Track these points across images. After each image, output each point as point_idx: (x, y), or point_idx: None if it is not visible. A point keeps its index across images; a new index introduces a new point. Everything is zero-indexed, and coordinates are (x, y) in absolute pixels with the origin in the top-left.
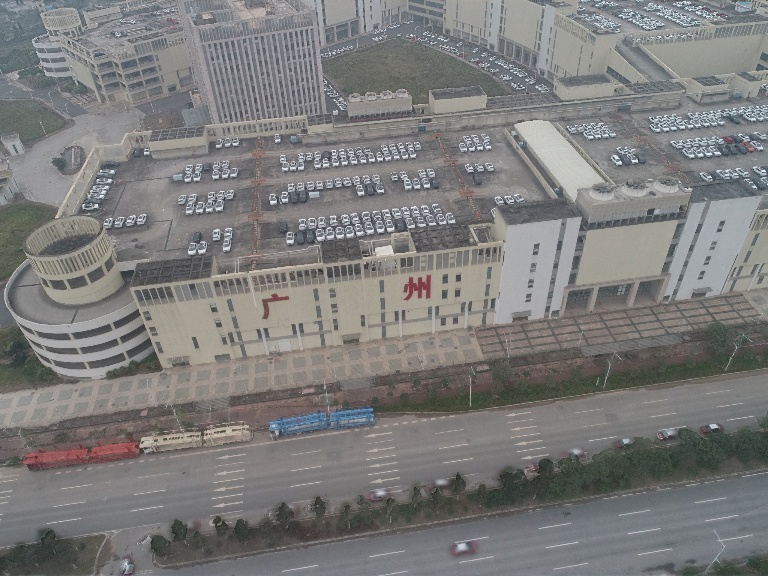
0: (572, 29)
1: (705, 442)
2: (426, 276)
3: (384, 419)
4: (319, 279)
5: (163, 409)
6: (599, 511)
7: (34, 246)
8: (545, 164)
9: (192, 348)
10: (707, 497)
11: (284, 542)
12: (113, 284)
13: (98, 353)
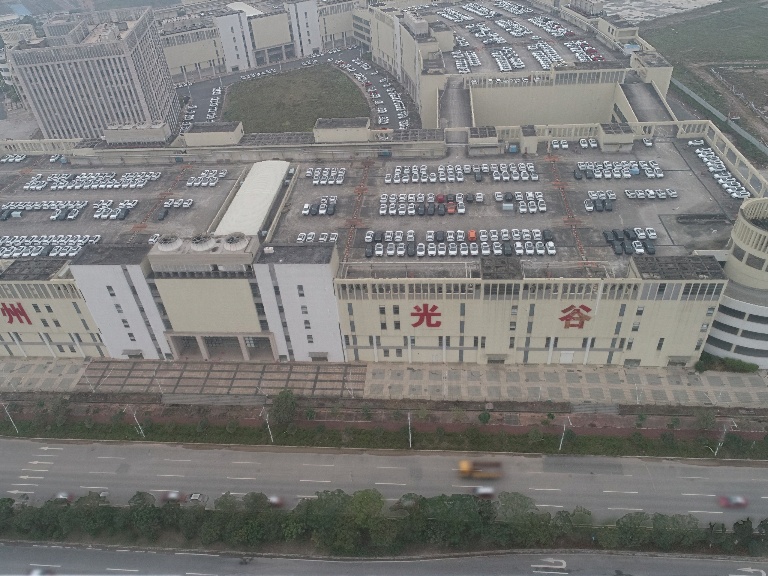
0: None
1: (142, 510)
2: (16, 303)
3: None
4: None
5: None
6: (18, 556)
7: None
8: (229, 206)
9: None
10: (123, 566)
11: None
12: None
13: None
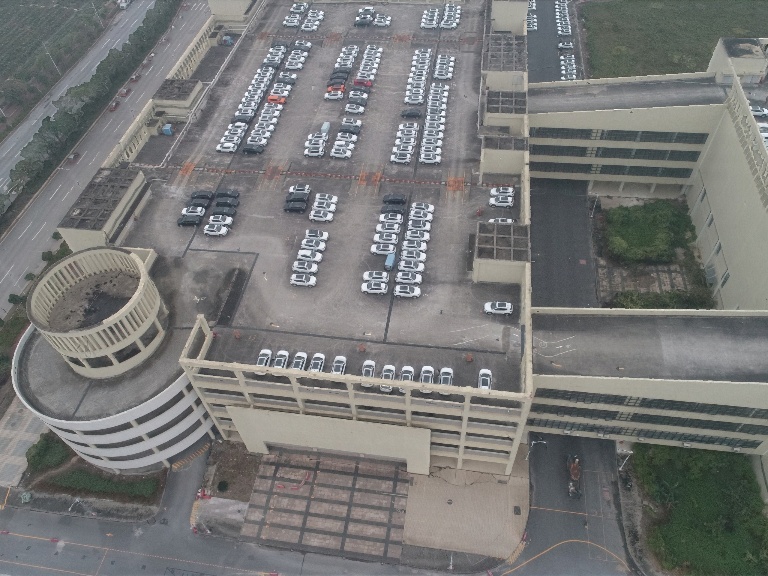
0: None
1: (139, 31)
2: None
3: None
4: None
5: None
6: None
7: None
8: None
9: None
10: None
11: None
12: None
13: None
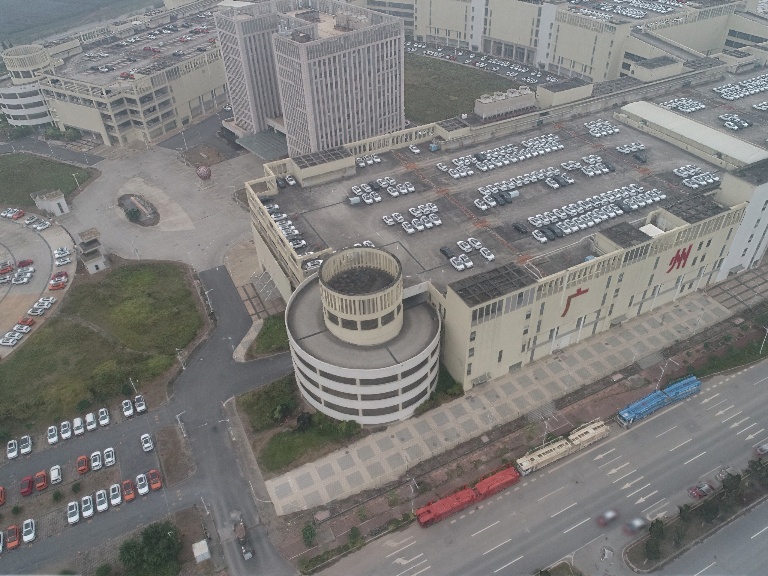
0: (580, 22)
1: None
2: (689, 246)
3: (701, 384)
4: (615, 266)
5: (500, 430)
6: None
7: None
8: (686, 136)
9: (495, 363)
10: None
11: (730, 513)
12: None
13: (415, 390)
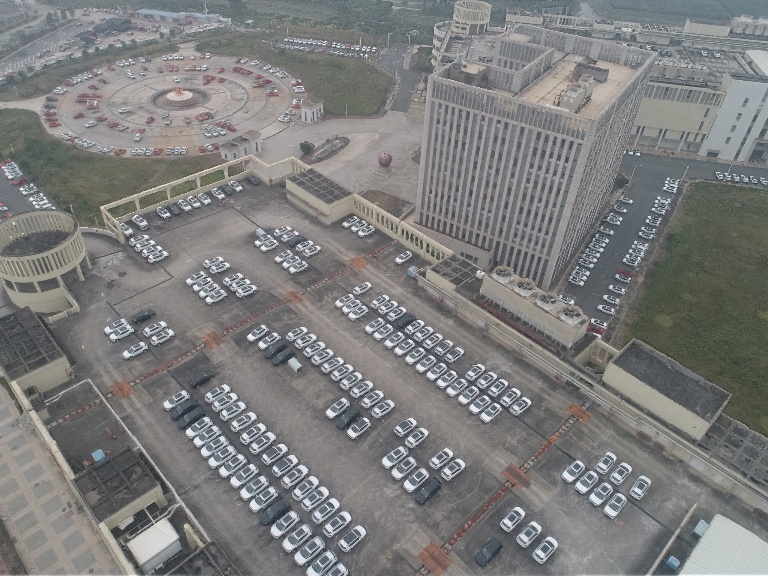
0: None
1: None
2: None
3: None
4: None
5: None
6: None
7: (28, 224)
8: None
9: None
10: None
11: None
12: (47, 305)
13: None
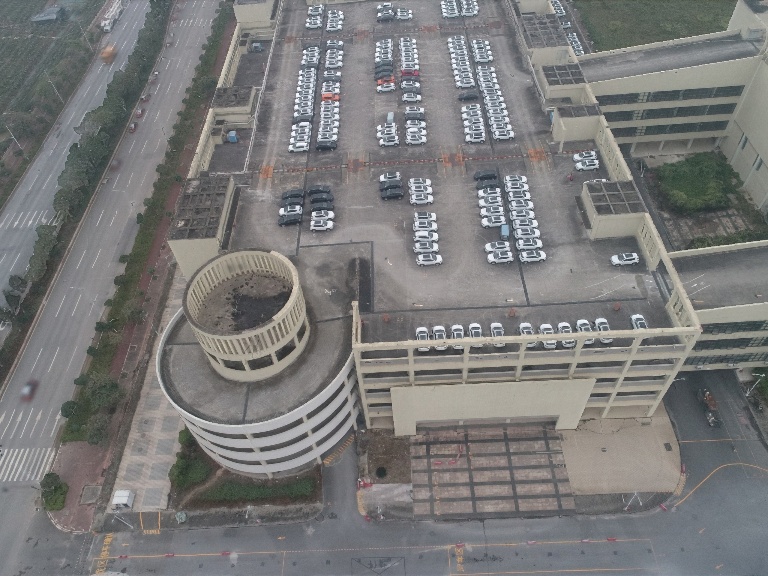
0: None
1: (138, 51)
2: None
3: None
4: None
5: None
6: None
7: None
8: None
9: None
10: None
11: None
12: None
13: None
